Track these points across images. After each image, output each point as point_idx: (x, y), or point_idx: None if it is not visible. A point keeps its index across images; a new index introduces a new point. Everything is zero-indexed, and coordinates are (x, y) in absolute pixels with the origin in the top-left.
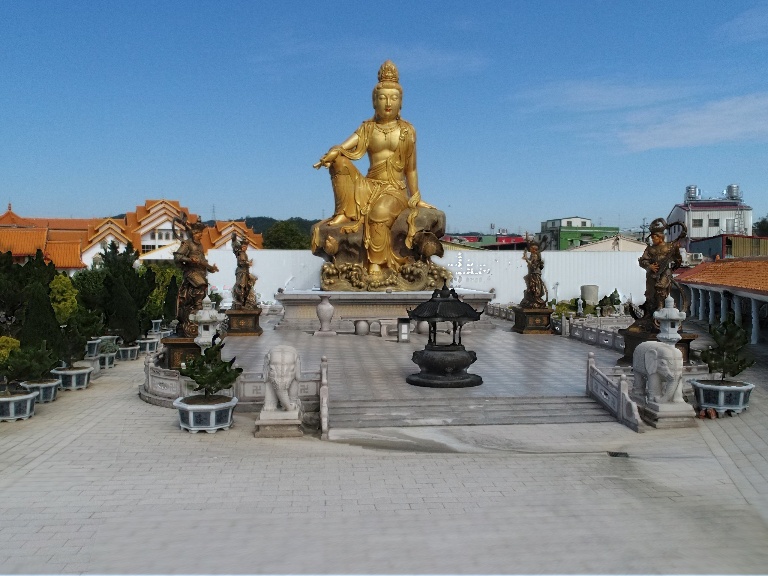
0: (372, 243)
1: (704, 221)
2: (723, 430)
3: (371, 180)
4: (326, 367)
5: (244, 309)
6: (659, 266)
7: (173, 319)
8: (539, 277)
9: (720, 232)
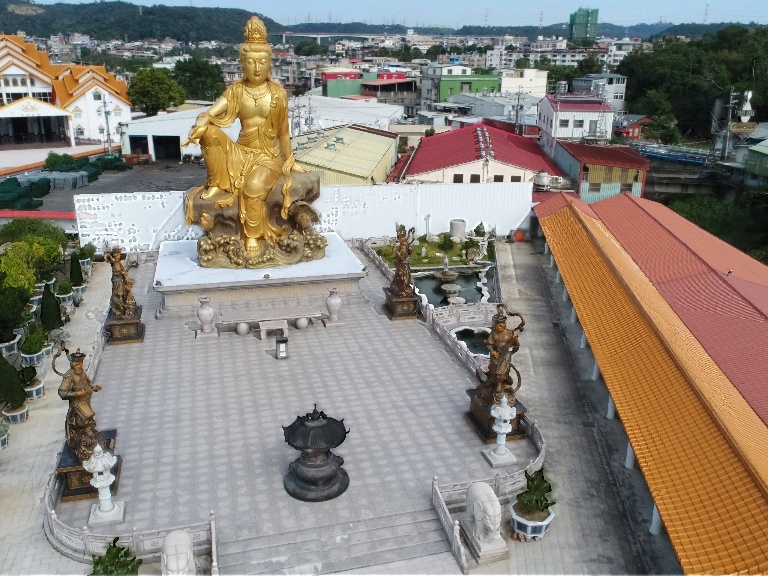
0: (248, 218)
1: (570, 121)
2: (526, 568)
3: (243, 148)
4: (214, 520)
5: (125, 318)
6: (500, 354)
7: (52, 327)
8: (407, 268)
9: (583, 133)
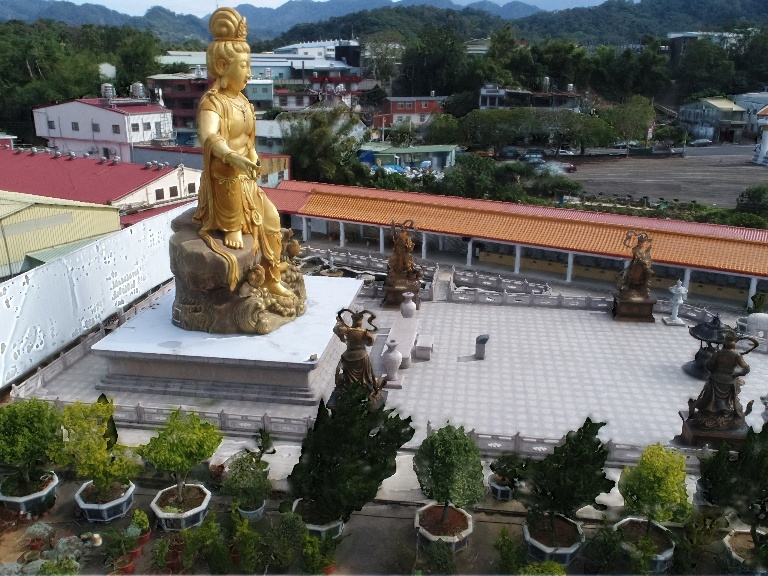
0: (276, 258)
1: (140, 125)
2: None
3: None
4: None
5: None
6: None
7: None
8: None
9: (153, 135)
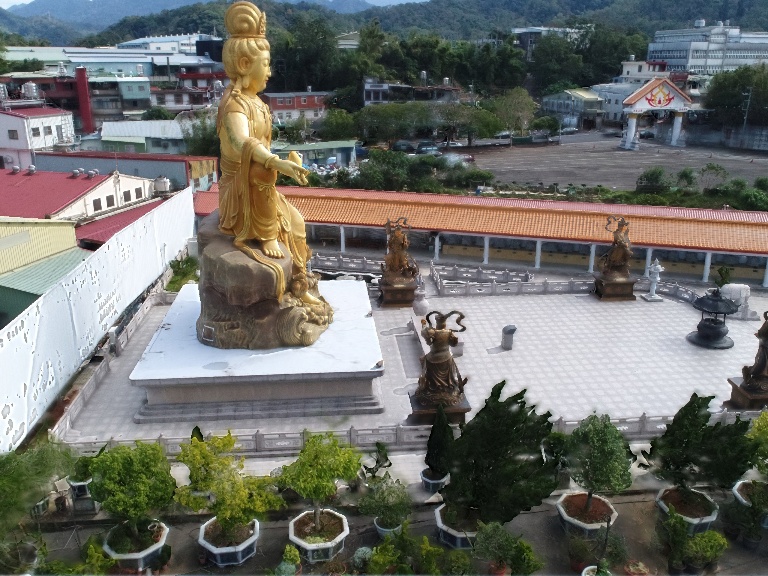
0: (304, 265)
1: (41, 129)
2: None
3: None
4: None
5: (463, 396)
6: None
7: None
8: None
9: (55, 140)
